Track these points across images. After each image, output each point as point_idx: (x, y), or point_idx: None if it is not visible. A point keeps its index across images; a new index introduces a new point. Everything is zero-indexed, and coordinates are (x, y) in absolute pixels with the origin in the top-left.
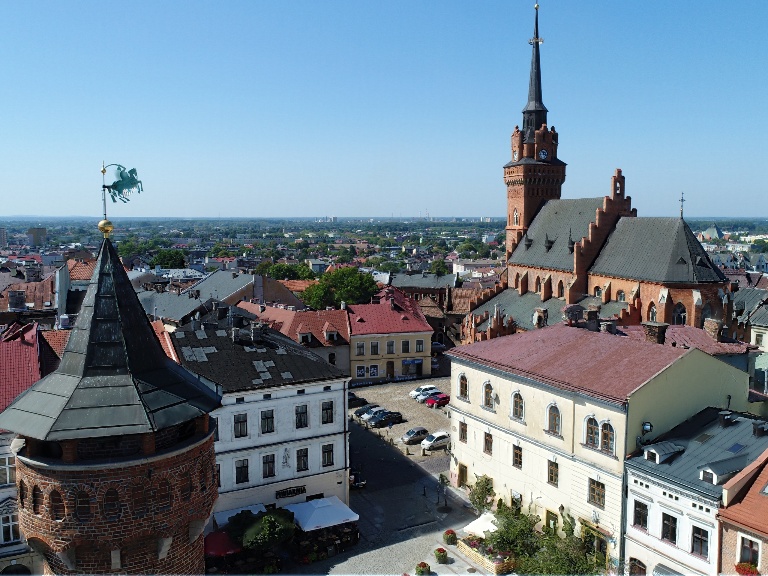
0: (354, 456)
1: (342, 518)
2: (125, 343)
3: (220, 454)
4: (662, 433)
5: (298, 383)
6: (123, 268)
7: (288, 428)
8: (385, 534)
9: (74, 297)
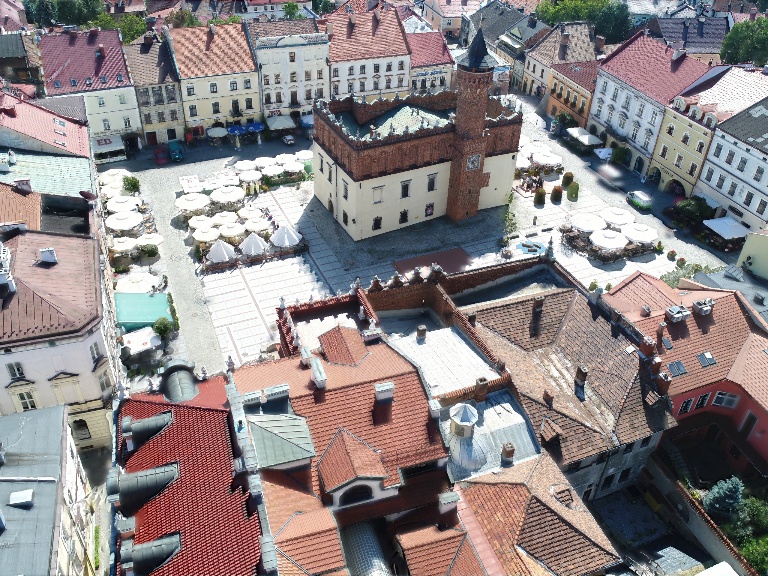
0: None
1: (721, 232)
2: (471, 48)
3: (716, 165)
4: (765, 277)
5: (764, 153)
6: (481, 34)
7: (750, 175)
8: None
9: None
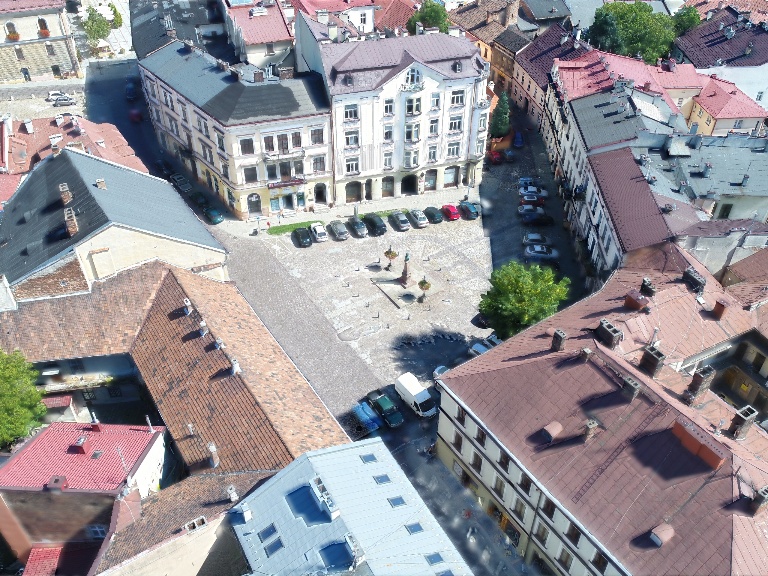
0: (117, 97)
1: None
2: None
3: None
4: None
5: None
6: None
7: None
8: (136, 61)
9: (313, 75)
